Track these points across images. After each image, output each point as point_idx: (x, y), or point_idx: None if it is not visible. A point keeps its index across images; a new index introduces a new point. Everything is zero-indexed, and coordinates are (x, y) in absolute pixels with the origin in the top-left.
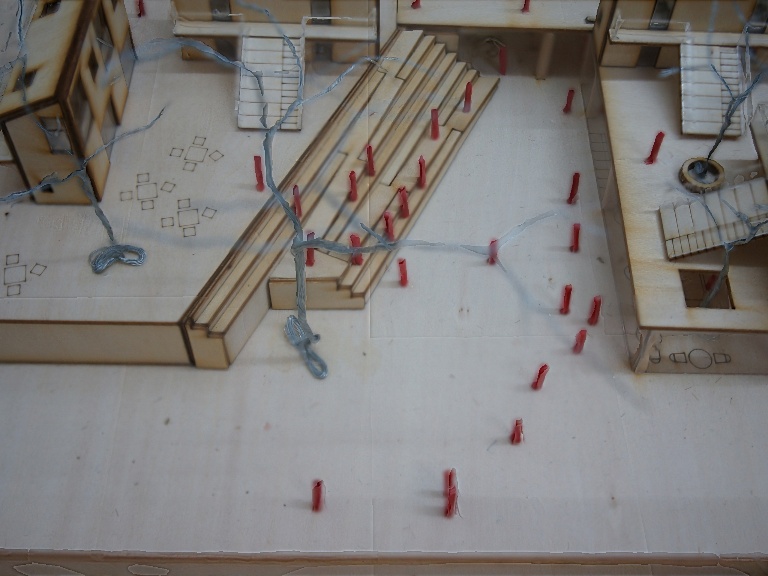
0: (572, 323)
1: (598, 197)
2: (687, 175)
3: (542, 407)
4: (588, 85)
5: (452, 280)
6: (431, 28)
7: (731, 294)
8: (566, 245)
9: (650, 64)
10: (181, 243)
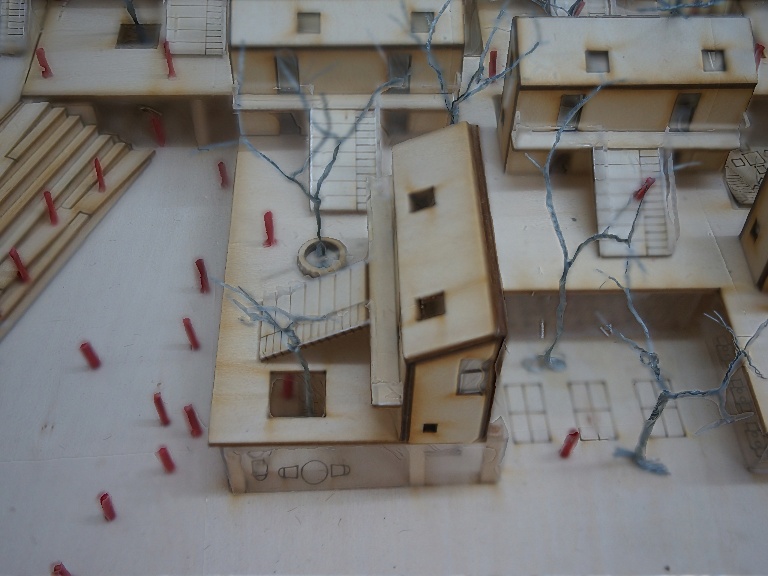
0: (172, 436)
1: None
2: (302, 259)
3: (112, 543)
4: None
5: (43, 391)
6: (61, 99)
7: (325, 399)
8: (188, 342)
9: (295, 131)
10: None
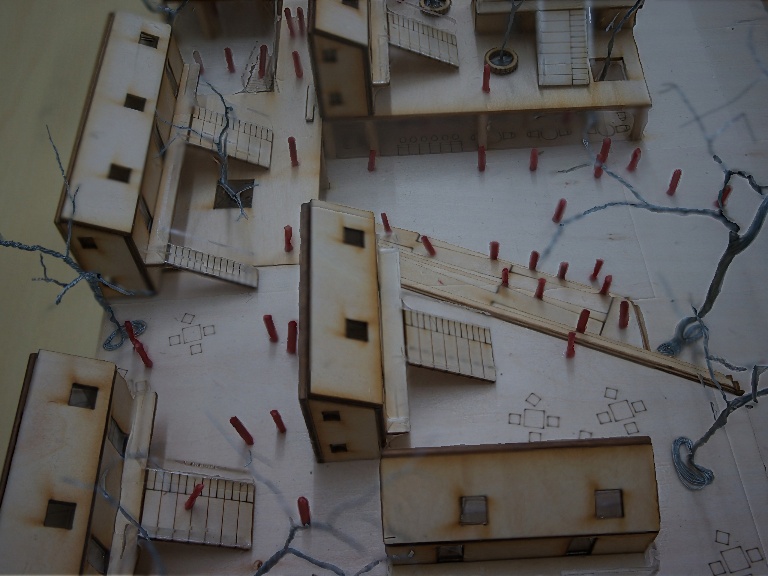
0: None
1: (473, 152)
2: (507, 66)
3: (687, 190)
4: (337, 153)
5: (581, 246)
6: None
7: (610, 58)
8: (529, 173)
9: None
10: (655, 411)
